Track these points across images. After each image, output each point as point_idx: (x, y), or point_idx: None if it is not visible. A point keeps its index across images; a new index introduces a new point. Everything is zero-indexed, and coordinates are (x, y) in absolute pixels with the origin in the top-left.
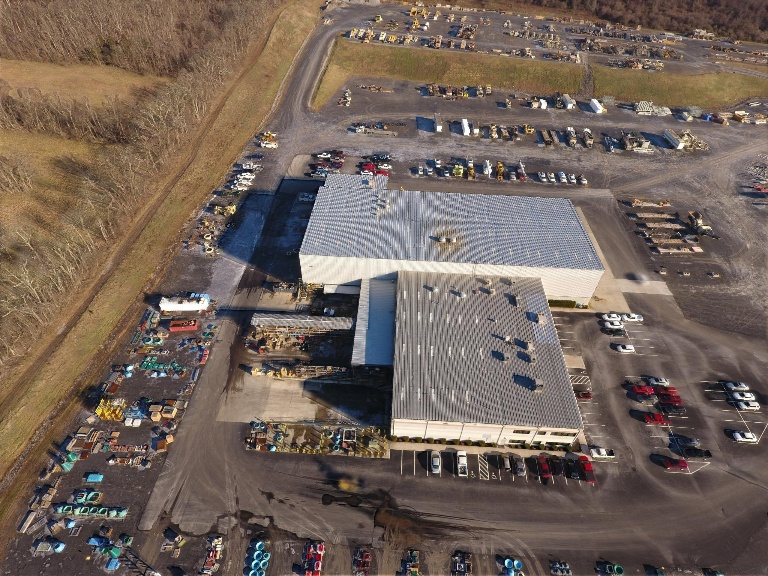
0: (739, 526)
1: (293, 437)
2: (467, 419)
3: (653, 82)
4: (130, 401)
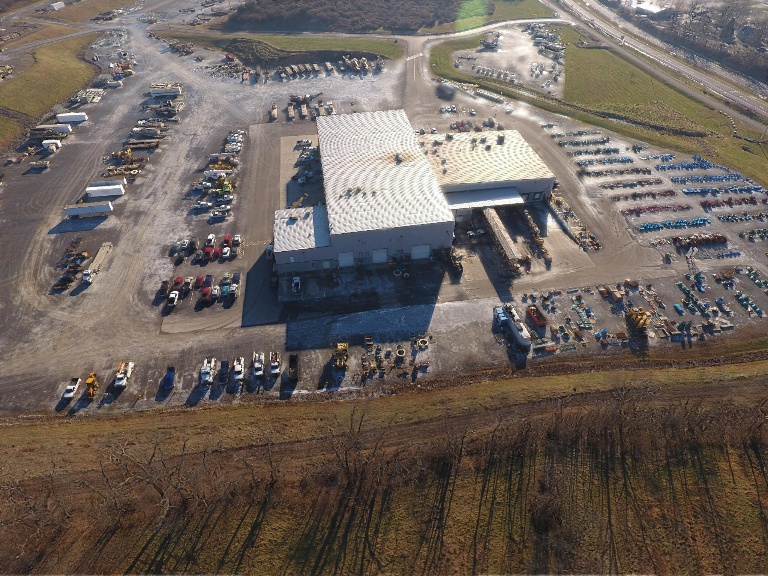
0: None
1: (579, 231)
2: (538, 157)
3: (37, 81)
4: (621, 319)
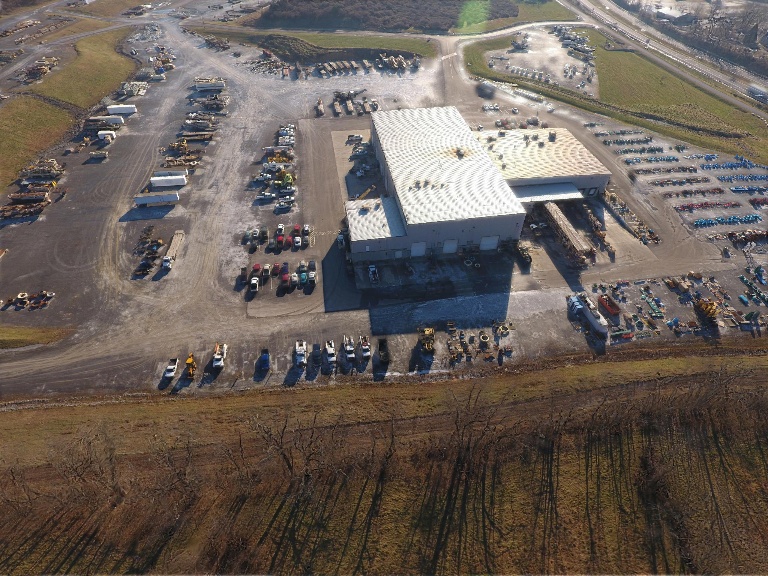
0: (560, 118)
1: (637, 226)
2: None
3: (83, 73)
4: (690, 309)
